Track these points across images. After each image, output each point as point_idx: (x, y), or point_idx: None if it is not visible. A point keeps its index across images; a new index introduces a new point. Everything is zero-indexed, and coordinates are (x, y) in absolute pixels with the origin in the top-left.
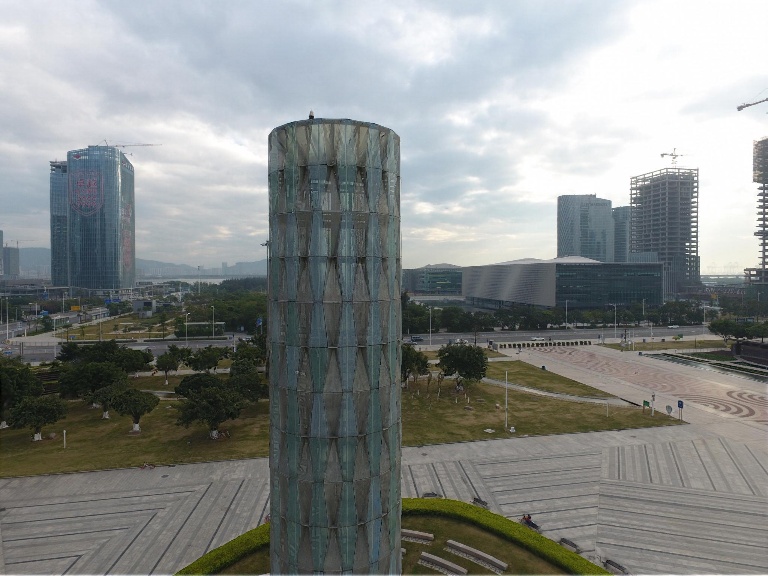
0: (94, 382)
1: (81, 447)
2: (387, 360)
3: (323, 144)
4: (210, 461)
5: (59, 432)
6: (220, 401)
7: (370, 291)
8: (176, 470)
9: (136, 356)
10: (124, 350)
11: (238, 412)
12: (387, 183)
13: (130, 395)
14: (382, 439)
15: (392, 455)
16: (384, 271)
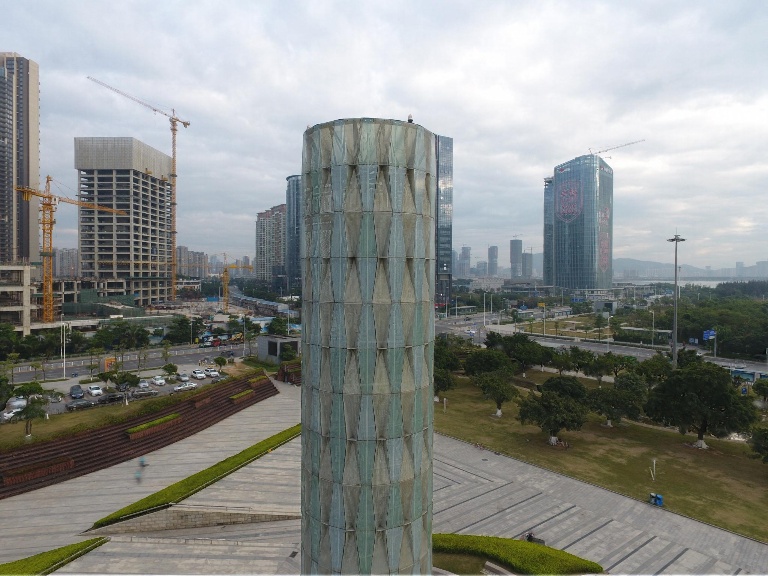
0: (486, 366)
1: (454, 415)
2: (358, 367)
3: (306, 154)
4: (529, 463)
5: (452, 400)
6: (553, 407)
7: (335, 292)
8: (497, 458)
9: (534, 351)
10: (533, 344)
11: (573, 424)
12: (359, 177)
13: (493, 382)
14: (350, 449)
15: (368, 473)
16: (357, 272)
